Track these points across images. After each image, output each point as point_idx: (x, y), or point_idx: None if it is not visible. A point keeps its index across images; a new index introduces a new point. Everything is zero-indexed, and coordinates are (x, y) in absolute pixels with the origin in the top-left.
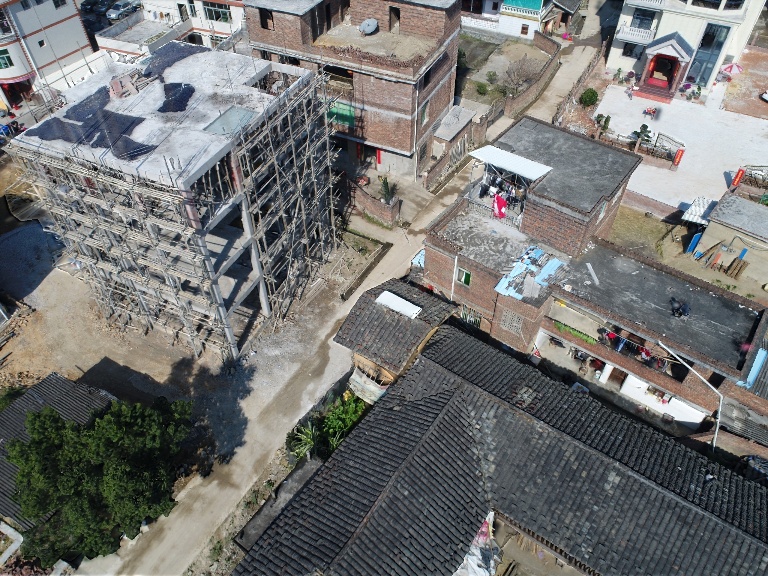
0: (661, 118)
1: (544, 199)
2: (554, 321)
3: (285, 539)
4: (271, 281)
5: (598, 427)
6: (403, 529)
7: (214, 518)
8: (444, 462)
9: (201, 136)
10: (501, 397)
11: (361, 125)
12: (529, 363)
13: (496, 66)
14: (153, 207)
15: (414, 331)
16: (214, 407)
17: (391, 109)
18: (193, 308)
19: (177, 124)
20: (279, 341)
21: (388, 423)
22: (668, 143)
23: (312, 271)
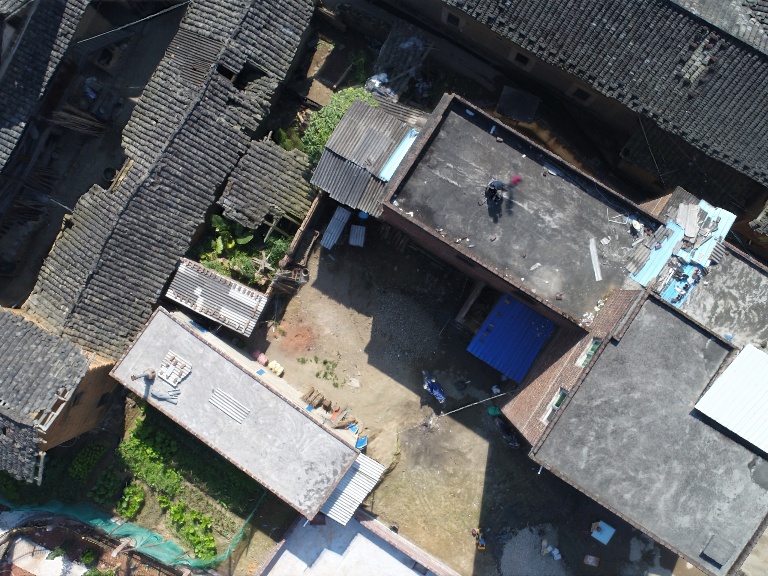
0: None
1: None
2: None
3: None
4: None
5: (617, 34)
6: None
7: None
8: None
9: None
10: (735, 46)
11: None
12: None
13: None
14: None
15: None
16: None
17: None
18: None
19: None
20: None
21: None
22: None
23: None
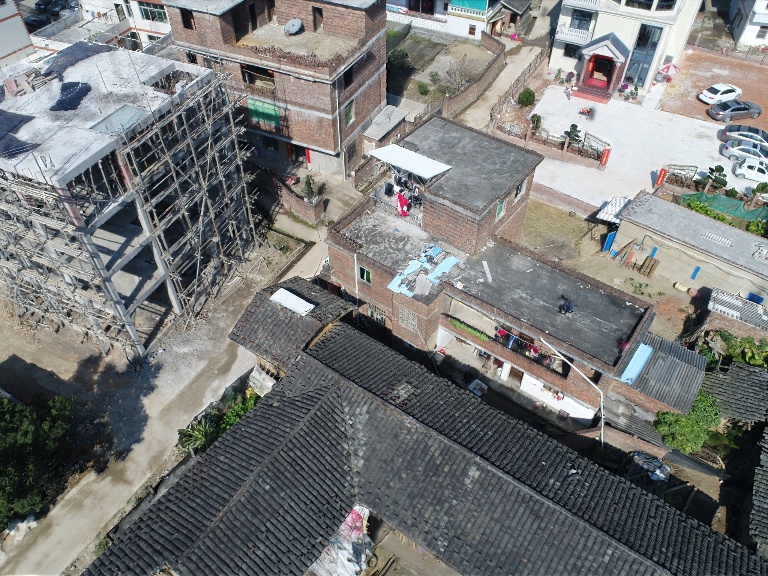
0: (596, 118)
1: (439, 197)
2: (450, 318)
3: (144, 533)
4: (176, 279)
5: (470, 423)
6: (260, 523)
7: (103, 514)
8: (311, 457)
9: (86, 134)
10: (375, 393)
11: (286, 124)
12: (428, 360)
13: (441, 66)
14: (40, 205)
15: (305, 328)
16: (116, 404)
17: (312, 108)
18: (94, 306)
19: (65, 123)
20: (189, 339)
21: (264, 419)
22: (595, 143)
23: (231, 269)
